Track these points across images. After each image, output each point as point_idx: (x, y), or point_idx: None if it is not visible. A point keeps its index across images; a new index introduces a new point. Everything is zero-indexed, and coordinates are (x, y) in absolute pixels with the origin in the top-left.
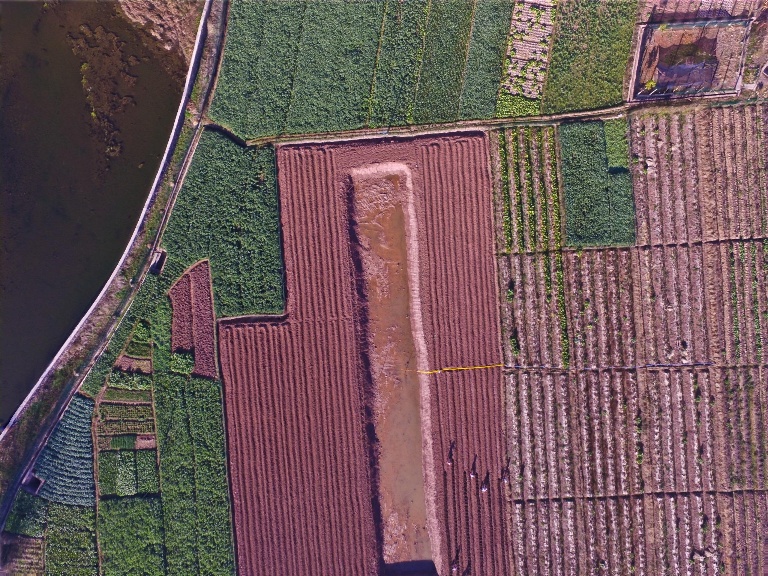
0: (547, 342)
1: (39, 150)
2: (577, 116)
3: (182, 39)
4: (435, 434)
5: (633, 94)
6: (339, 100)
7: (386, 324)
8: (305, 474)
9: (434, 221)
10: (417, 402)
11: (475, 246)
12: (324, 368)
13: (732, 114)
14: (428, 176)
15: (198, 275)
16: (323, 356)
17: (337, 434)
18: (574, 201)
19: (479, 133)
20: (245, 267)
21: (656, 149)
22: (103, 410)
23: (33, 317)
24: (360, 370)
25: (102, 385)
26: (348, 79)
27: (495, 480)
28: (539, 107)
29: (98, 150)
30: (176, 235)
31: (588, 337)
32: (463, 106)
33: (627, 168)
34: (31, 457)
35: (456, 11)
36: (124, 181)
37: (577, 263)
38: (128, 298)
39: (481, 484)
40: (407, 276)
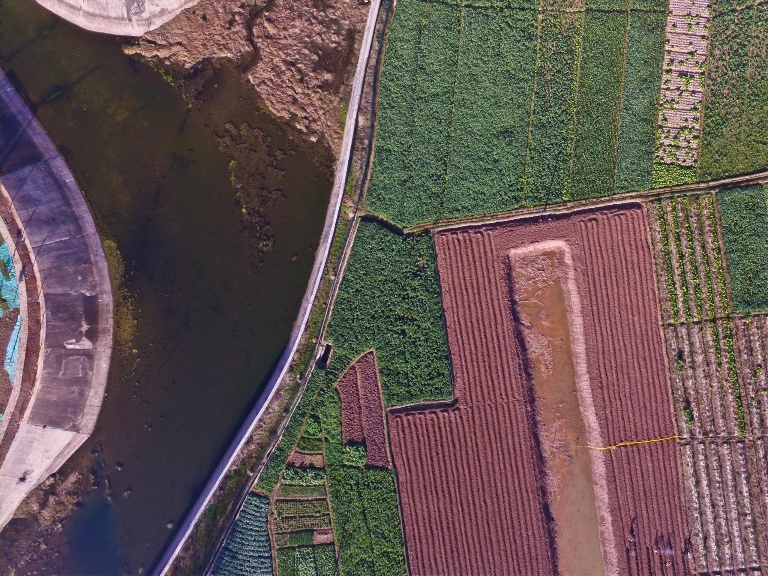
0: (721, 410)
1: (192, 250)
2: (735, 181)
3: (328, 130)
4: (614, 511)
5: None
6: (495, 182)
7: (553, 401)
8: (485, 559)
9: (598, 296)
10: (590, 478)
11: (641, 318)
12: (498, 451)
13: None
14: (589, 252)
15: (364, 366)
16: (496, 439)
17: (515, 517)
18: (739, 267)
19: (636, 205)
20: (412, 356)
21: None
22: (279, 508)
23: (196, 416)
24: (533, 451)
25: (276, 483)
26: (502, 161)
27: (679, 554)
28: (695, 175)
29: (251, 245)
30: (342, 329)
31: (763, 403)
32: (619, 179)
33: None
34: (210, 559)
35: (605, 85)
36: (278, 274)
37: (746, 329)
38: (296, 394)
39: (665, 559)
40: (571, 351)
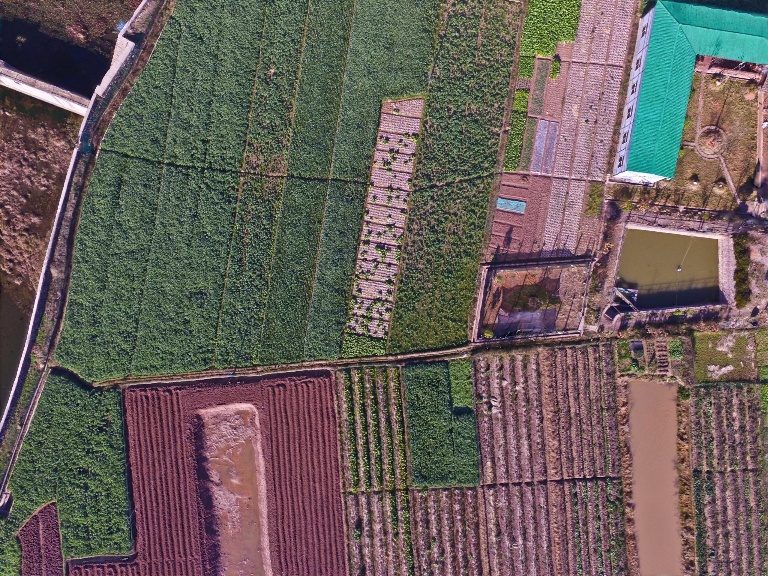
0: None
1: None
2: (422, 356)
3: (32, 274)
4: None
5: (477, 335)
6: (184, 344)
7: (238, 558)
8: None
9: (281, 462)
10: None
11: (322, 485)
12: None
13: (575, 355)
14: (274, 417)
15: (46, 516)
16: None
17: None
18: (419, 442)
19: (325, 372)
20: (92, 510)
21: (500, 389)
22: None
23: None
24: None
25: None
26: (193, 322)
27: None
28: (385, 347)
29: None
30: (22, 480)
31: (435, 575)
32: (308, 348)
33: (471, 408)
34: None
35: (301, 253)
36: None
37: (423, 502)
38: None
39: None
40: (258, 510)
